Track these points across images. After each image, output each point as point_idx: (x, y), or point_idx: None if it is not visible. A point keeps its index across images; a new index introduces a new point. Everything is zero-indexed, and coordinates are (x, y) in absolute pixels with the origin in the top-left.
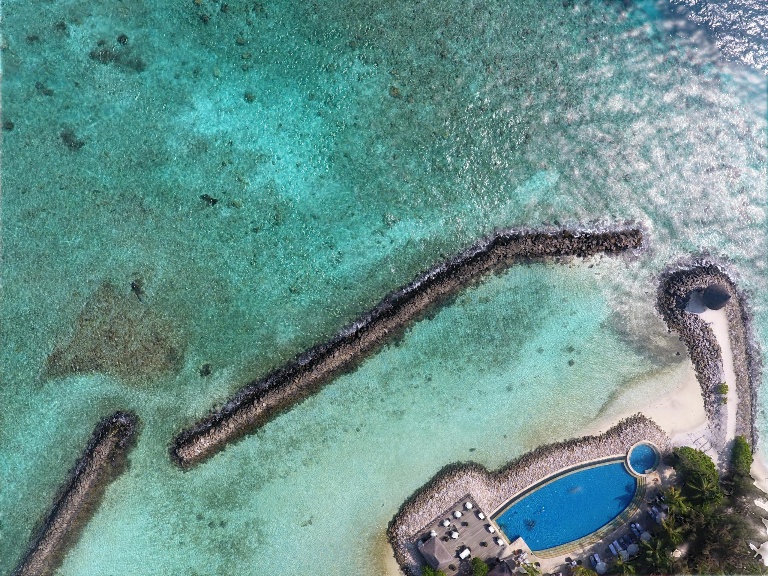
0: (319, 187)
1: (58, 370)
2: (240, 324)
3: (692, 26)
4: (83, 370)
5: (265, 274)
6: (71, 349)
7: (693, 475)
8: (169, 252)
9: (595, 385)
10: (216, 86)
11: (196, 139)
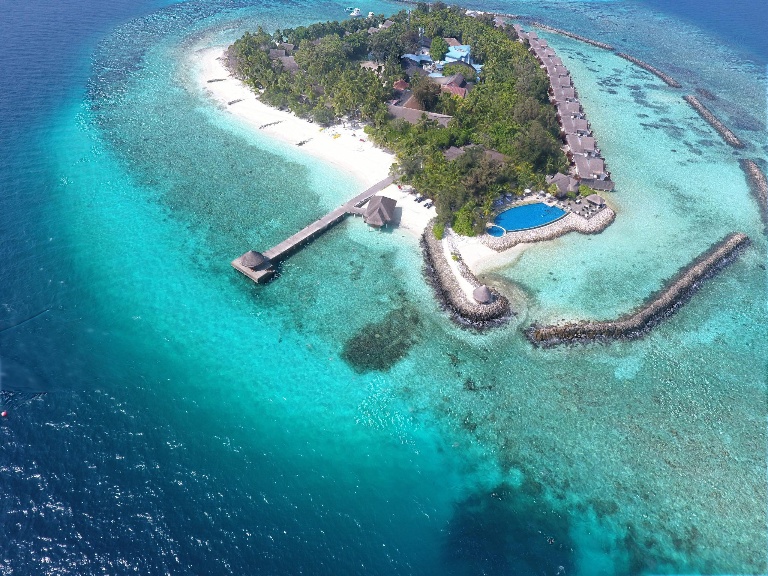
0: None
1: None
2: (764, 287)
3: (546, 530)
4: None
5: None
6: None
7: None
8: None
9: None
10: None
11: None
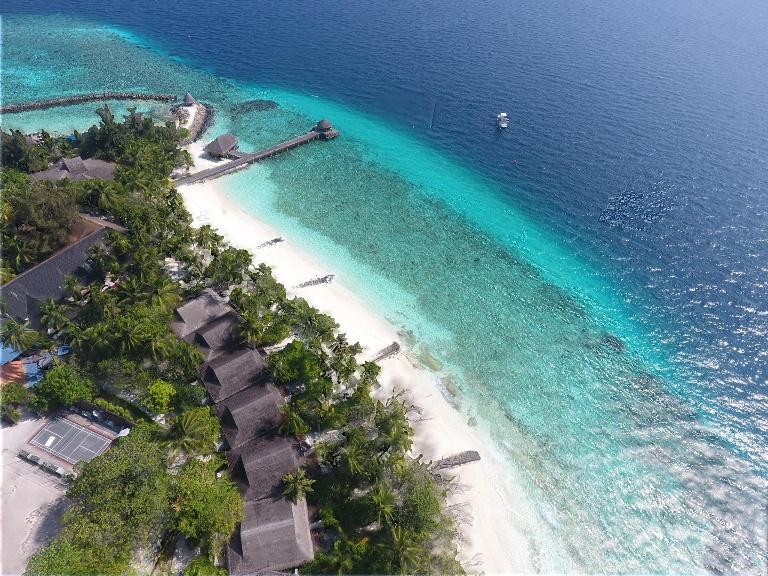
0: None
1: None
2: None
3: None
4: None
5: None
6: None
7: None
8: None
9: None
10: (20, 67)
11: (1, 73)
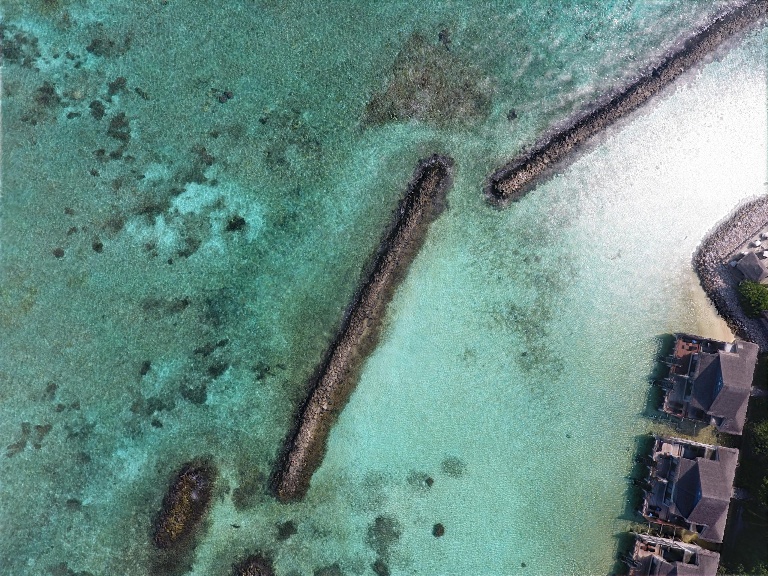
0: None
1: (376, 117)
2: (541, 71)
3: None
4: (400, 116)
5: (561, 23)
6: (387, 97)
7: None
8: (471, 4)
9: None
10: None
11: None
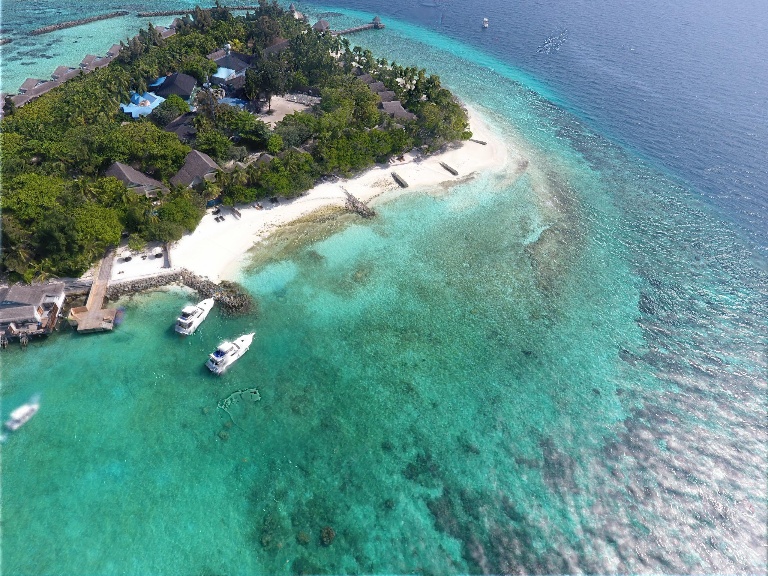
0: None
1: (114, 8)
2: None
3: None
4: None
5: None
6: None
7: None
8: None
9: None
10: None
11: None
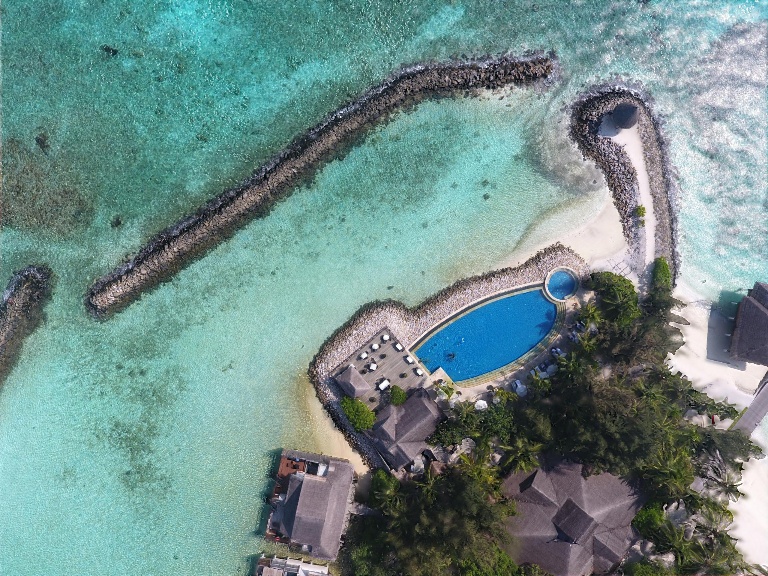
0: (220, 33)
1: None
2: (148, 174)
3: None
4: None
5: (170, 123)
6: None
7: (610, 294)
8: (72, 105)
9: (512, 218)
10: None
11: None
